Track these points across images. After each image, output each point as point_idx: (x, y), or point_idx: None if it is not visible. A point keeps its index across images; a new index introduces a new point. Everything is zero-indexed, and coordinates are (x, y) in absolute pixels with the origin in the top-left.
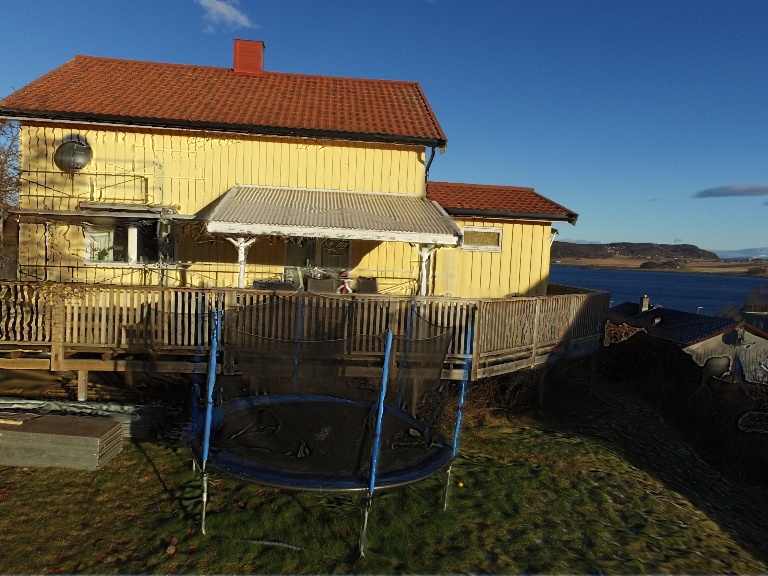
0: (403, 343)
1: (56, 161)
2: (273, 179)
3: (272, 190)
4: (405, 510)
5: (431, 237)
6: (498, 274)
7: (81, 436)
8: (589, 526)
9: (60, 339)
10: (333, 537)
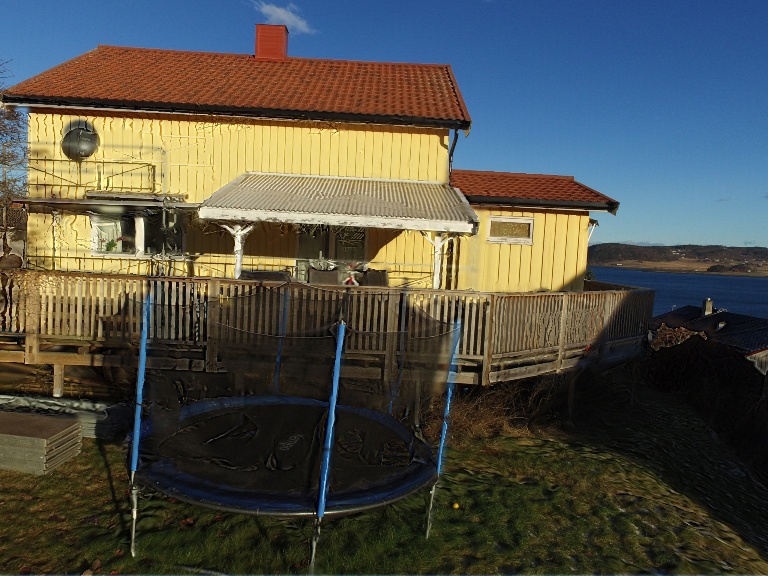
0: (404, 341)
1: (64, 149)
2: (284, 166)
3: (282, 177)
4: (379, 536)
5: (443, 224)
6: (528, 269)
7: (27, 436)
8: (605, 564)
9: (34, 330)
10: (282, 567)
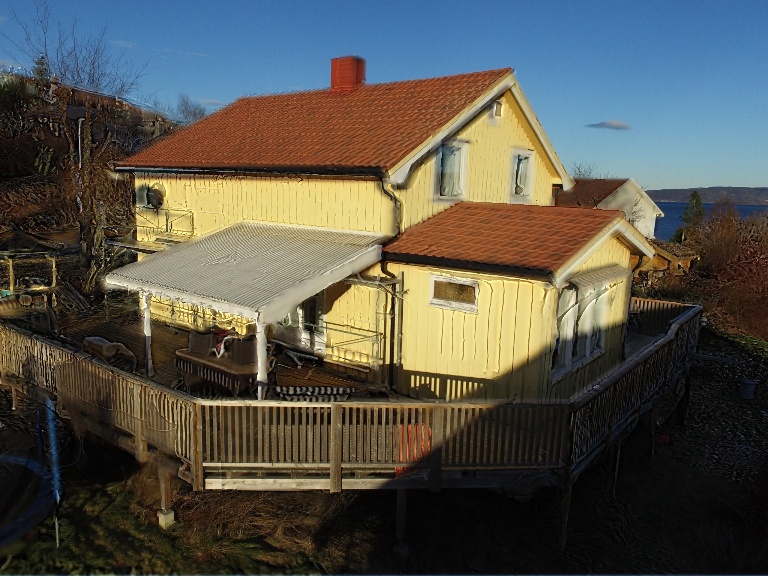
0: (146, 428)
1: None
2: (266, 214)
3: (258, 227)
4: None
5: (238, 309)
6: (474, 342)
7: None
8: None
9: (1, 362)
10: None
